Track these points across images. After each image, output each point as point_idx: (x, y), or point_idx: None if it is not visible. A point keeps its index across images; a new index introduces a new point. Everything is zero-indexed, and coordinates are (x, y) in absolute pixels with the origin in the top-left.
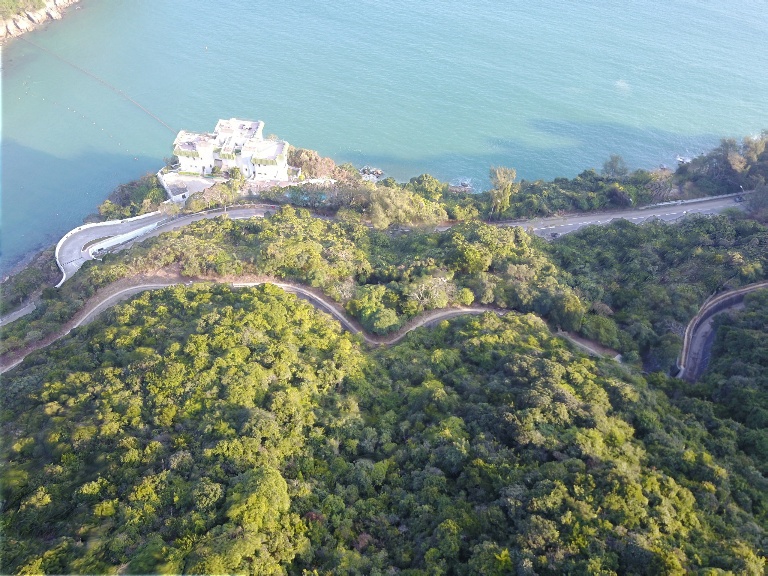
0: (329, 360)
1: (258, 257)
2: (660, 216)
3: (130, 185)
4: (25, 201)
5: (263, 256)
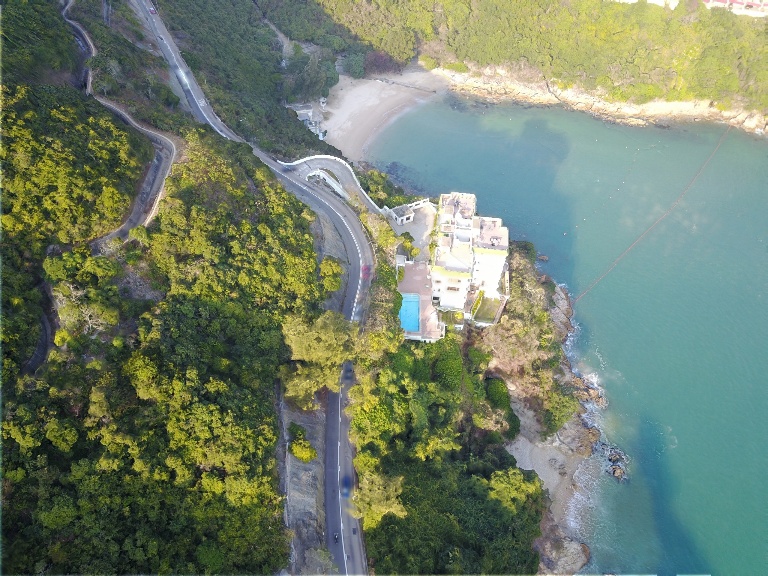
0: None
1: None
2: None
3: None
4: (488, 179)
5: None
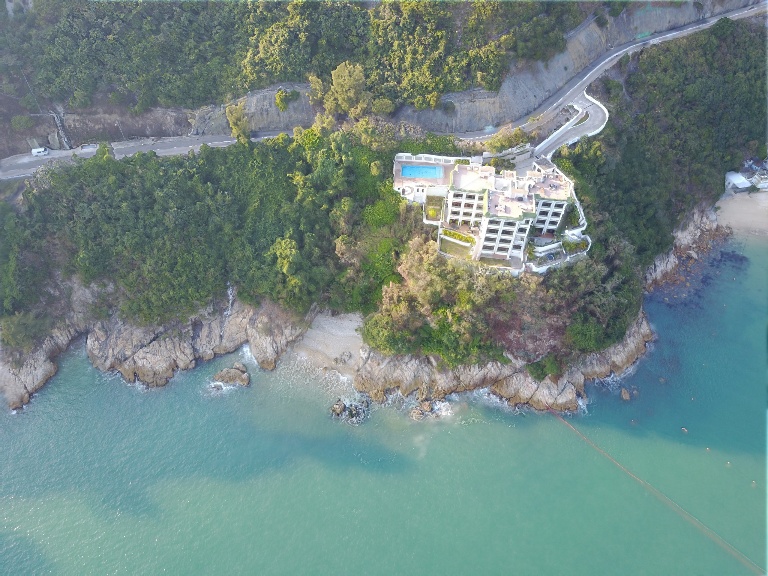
0: None
1: None
2: None
3: (620, 257)
4: (766, 355)
5: None
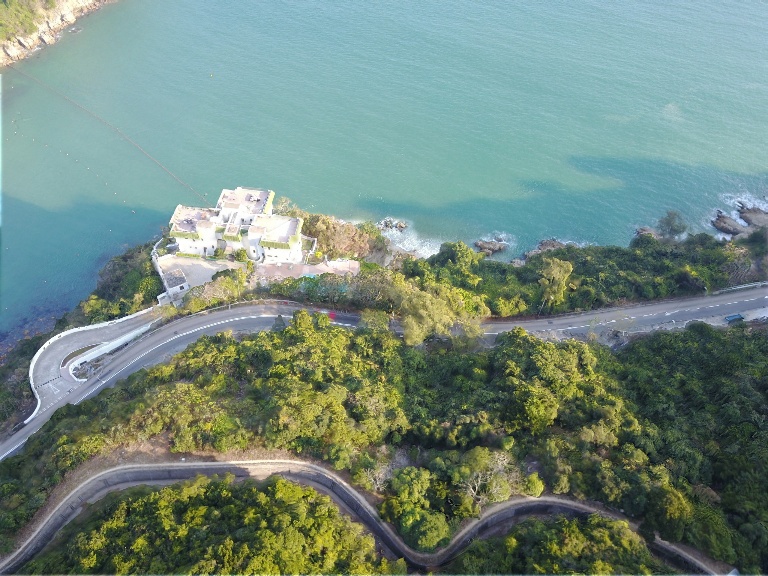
0: None
1: (267, 427)
2: (738, 303)
3: (123, 259)
4: (10, 265)
5: (273, 427)
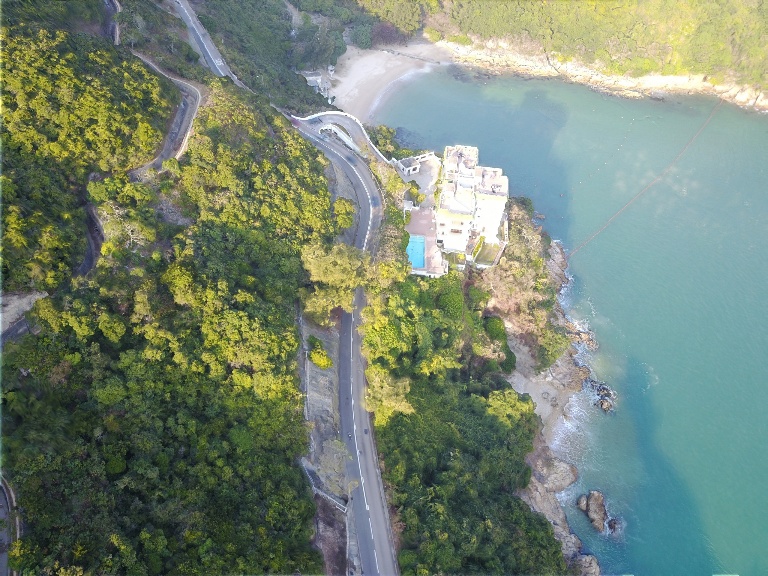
0: (32, 129)
1: None
2: None
3: None
4: (489, 145)
5: None
